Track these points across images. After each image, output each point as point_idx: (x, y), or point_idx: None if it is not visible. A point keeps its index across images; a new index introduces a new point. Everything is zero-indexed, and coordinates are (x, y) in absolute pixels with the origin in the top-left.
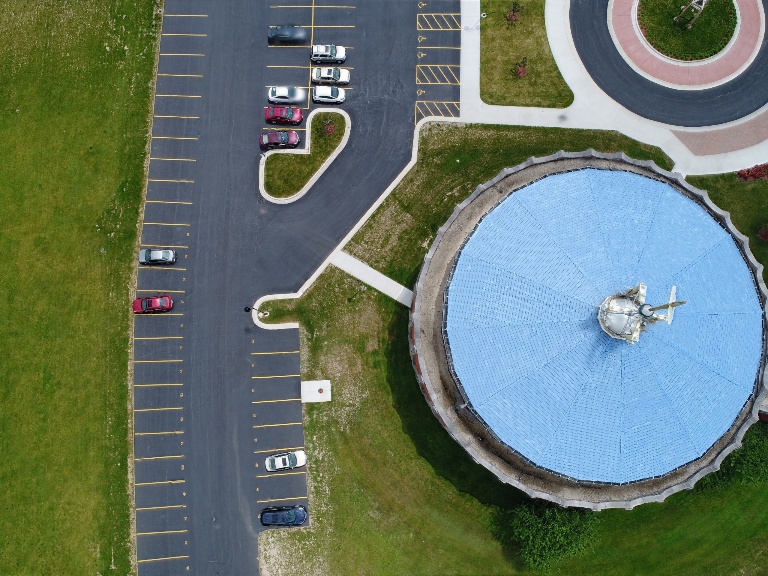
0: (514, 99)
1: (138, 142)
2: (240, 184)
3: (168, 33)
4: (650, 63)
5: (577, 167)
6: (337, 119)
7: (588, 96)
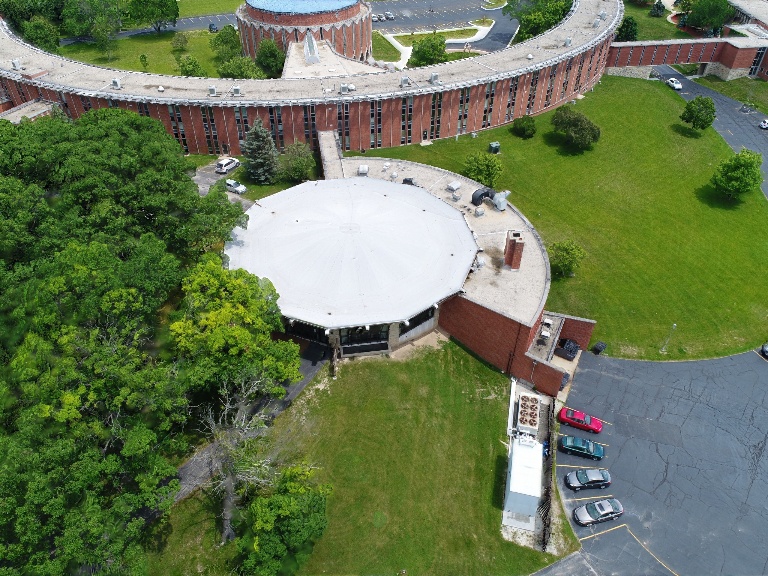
0: None
1: None
2: None
3: (377, 2)
4: None
5: (361, 5)
6: None
7: None
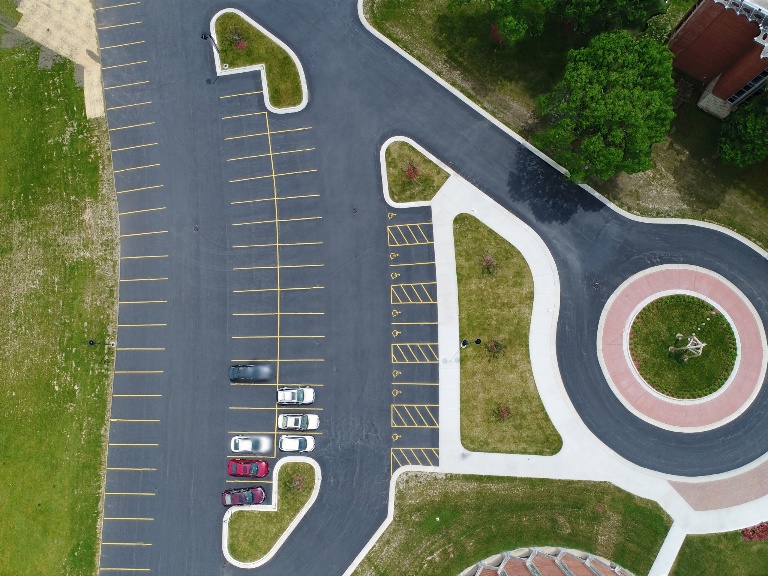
0: (498, 445)
1: (90, 499)
2: (202, 546)
3: (122, 370)
4: (644, 401)
5: None
6: (306, 470)
7: (578, 441)
